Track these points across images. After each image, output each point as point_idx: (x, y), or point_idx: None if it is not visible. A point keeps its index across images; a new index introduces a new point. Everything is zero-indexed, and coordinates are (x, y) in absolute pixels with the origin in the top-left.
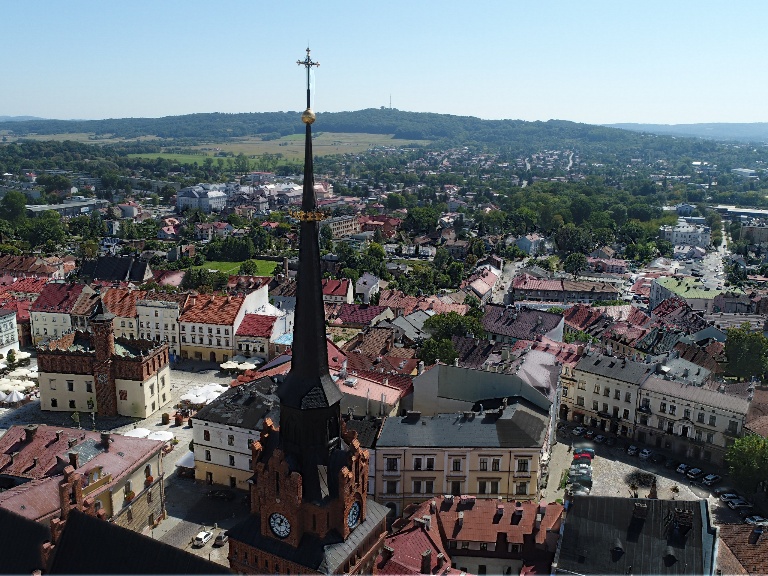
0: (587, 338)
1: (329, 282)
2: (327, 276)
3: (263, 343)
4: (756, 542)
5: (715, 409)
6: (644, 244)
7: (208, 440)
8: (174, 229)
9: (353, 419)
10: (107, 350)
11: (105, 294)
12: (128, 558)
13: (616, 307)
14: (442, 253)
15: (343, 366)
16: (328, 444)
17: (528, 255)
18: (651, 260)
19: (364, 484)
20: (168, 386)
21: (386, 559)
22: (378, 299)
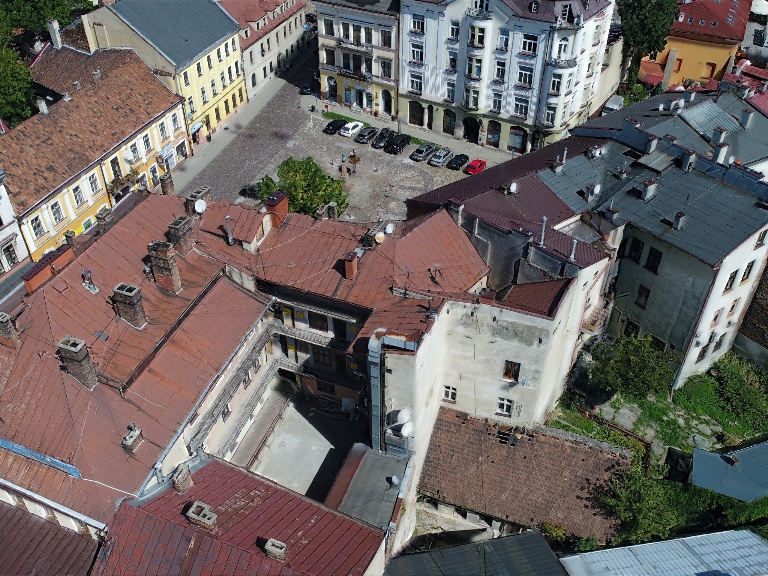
0: None
1: None
2: None
3: None
4: None
5: None
6: None
7: None
8: None
9: None
10: None
11: None
12: None
13: None
14: None
15: None
16: None
17: None
18: None
19: None
20: None
21: None
22: None
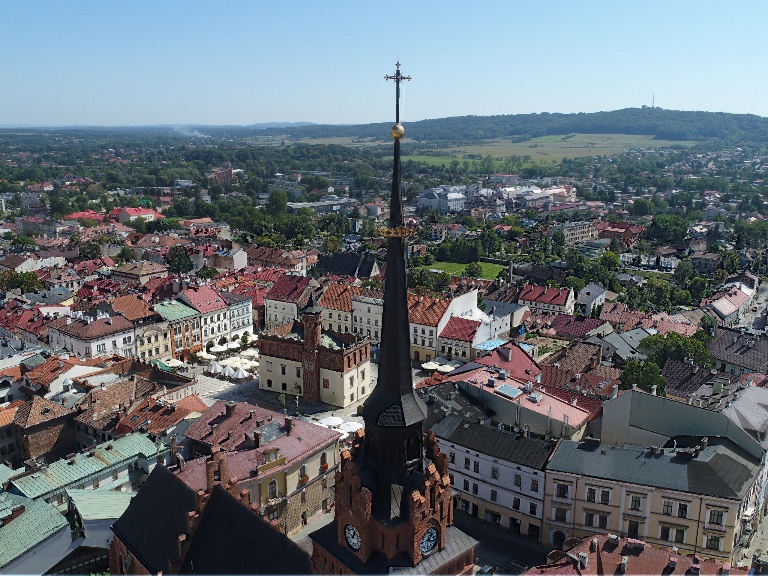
0: None
1: (548, 290)
2: (550, 283)
3: (465, 347)
4: None
5: None
6: None
7: None
8: None
9: None
10: (314, 340)
11: (327, 288)
12: (251, 539)
13: None
14: (684, 266)
15: (535, 380)
16: (406, 464)
17: None
18: None
19: (443, 511)
20: (368, 380)
21: None
22: (600, 311)
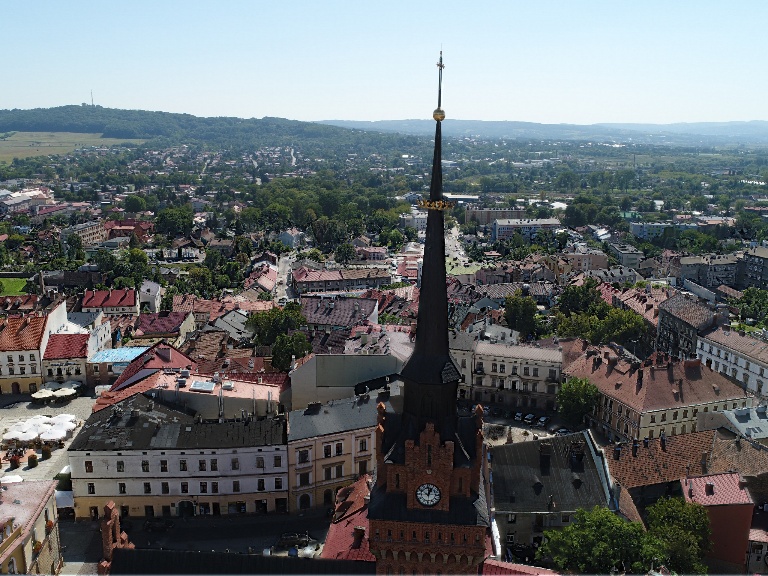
0: (393, 319)
1: (112, 293)
2: (99, 288)
3: (78, 364)
4: (619, 458)
5: (537, 362)
6: (390, 231)
7: (91, 472)
8: None
9: None
10: None
11: None
12: None
13: (401, 289)
14: (213, 254)
15: None
16: None
17: (292, 249)
18: (403, 245)
19: None
20: None
21: (359, 539)
22: (168, 306)
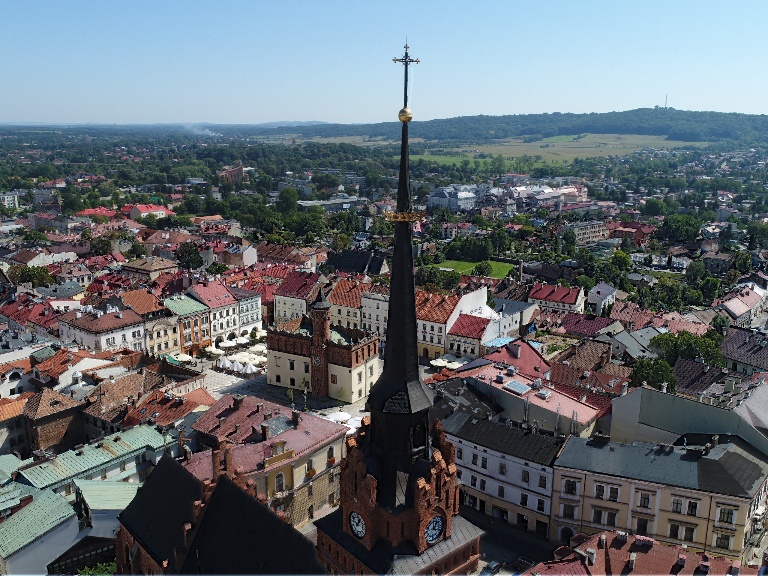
0: None
1: (558, 289)
2: (560, 282)
3: (474, 344)
4: None
5: None
6: None
7: None
8: (421, 227)
9: (538, 433)
10: (323, 336)
11: (336, 284)
12: (256, 528)
13: None
14: (696, 266)
15: (544, 377)
16: (411, 452)
17: None
18: None
19: (449, 500)
20: (376, 376)
21: None
22: None
